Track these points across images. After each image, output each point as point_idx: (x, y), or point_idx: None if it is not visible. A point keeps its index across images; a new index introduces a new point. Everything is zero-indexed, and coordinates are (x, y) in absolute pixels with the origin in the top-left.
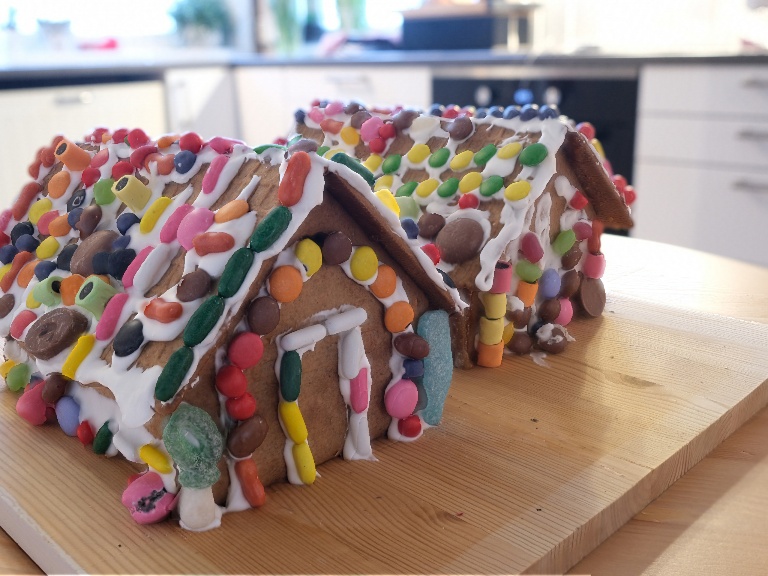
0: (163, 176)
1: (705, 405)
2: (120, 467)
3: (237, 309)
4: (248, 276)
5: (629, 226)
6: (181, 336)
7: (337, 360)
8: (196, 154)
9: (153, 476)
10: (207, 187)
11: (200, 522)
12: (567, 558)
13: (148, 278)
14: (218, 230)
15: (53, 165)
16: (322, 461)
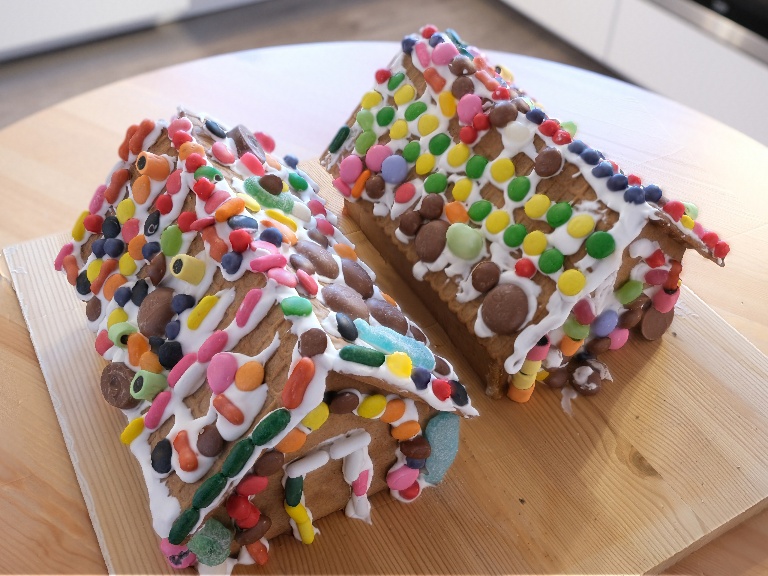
0: (215, 260)
1: (686, 522)
2: None
3: (238, 482)
4: (247, 464)
5: None
6: (196, 483)
7: (342, 464)
8: (243, 253)
9: None
10: (239, 323)
11: None
12: None
13: (185, 392)
14: (233, 399)
15: None
16: (326, 515)
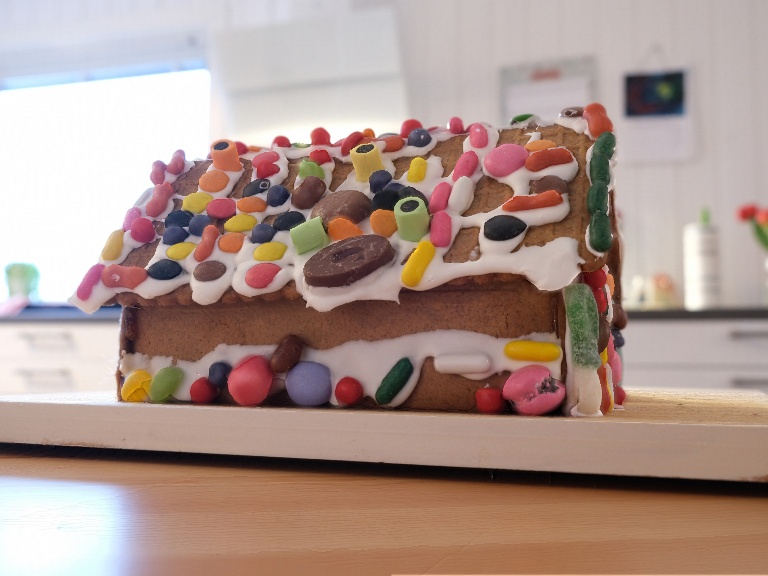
0: (391, 153)
1: None
2: (417, 411)
3: None
4: (611, 173)
5: None
6: (568, 217)
7: None
8: None
9: (536, 366)
10: (483, 141)
11: (599, 403)
12: None
13: (466, 200)
14: None
15: (180, 173)
16: None
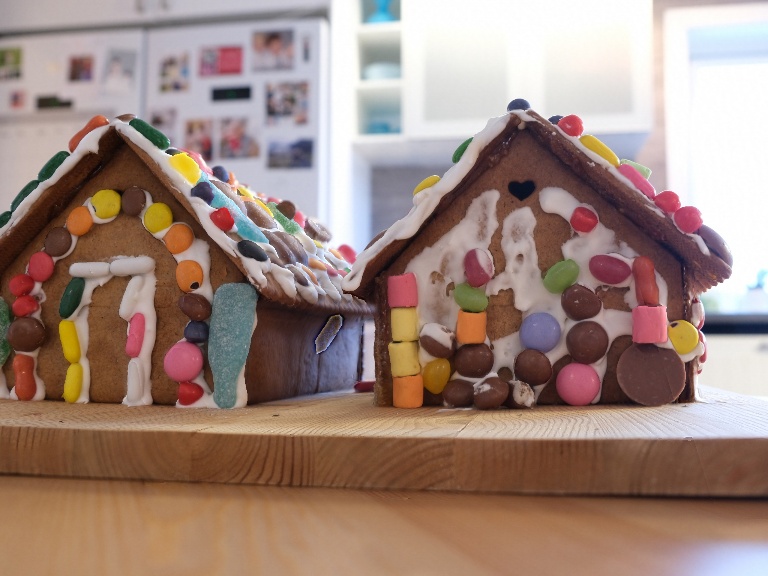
0: None
1: None
2: None
3: (17, 222)
4: None
5: (721, 273)
6: None
7: None
8: None
9: None
10: None
11: None
12: (9, 454)
13: None
14: None
15: None
16: (109, 400)
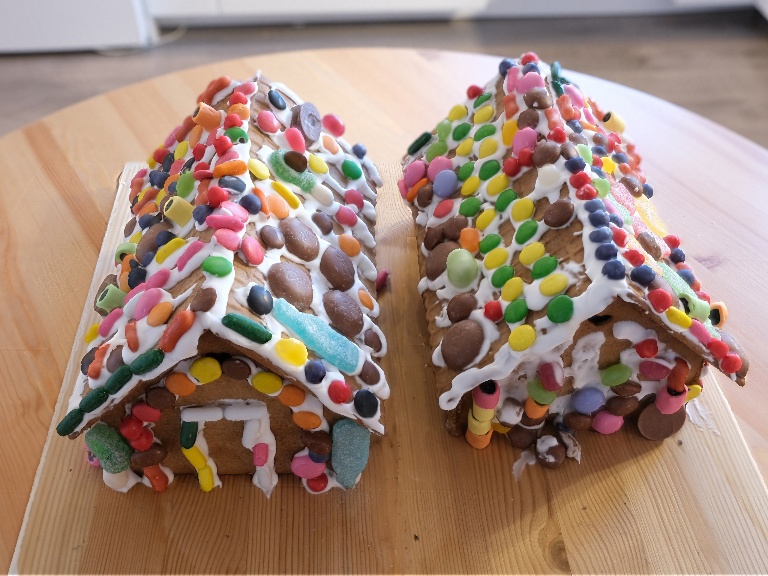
0: None
1: None
2: None
3: (118, 401)
4: (123, 387)
5: None
6: None
7: (243, 429)
8: (215, 209)
9: None
10: (178, 267)
11: (111, 486)
12: None
13: (129, 313)
14: (139, 329)
15: (211, 105)
16: (235, 473)
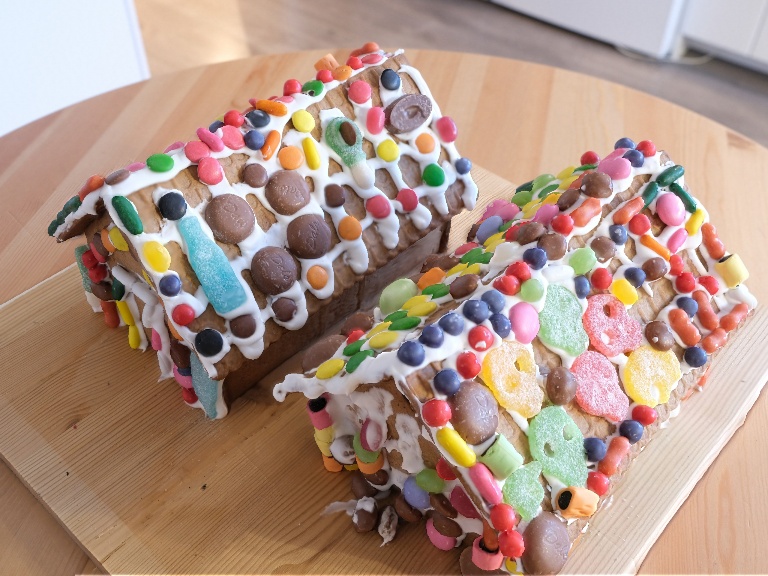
0: None
1: None
2: None
3: (69, 227)
4: None
5: None
6: None
7: None
8: None
9: None
10: None
11: None
12: None
13: None
14: None
15: None
16: None
